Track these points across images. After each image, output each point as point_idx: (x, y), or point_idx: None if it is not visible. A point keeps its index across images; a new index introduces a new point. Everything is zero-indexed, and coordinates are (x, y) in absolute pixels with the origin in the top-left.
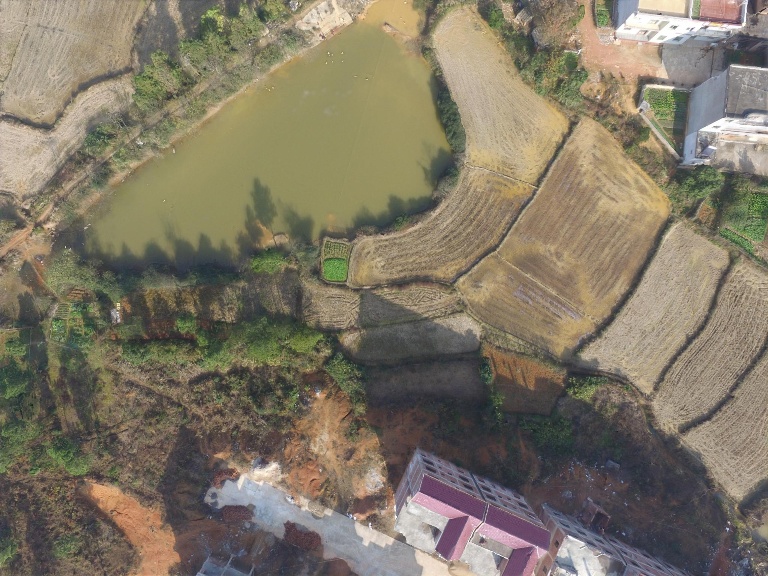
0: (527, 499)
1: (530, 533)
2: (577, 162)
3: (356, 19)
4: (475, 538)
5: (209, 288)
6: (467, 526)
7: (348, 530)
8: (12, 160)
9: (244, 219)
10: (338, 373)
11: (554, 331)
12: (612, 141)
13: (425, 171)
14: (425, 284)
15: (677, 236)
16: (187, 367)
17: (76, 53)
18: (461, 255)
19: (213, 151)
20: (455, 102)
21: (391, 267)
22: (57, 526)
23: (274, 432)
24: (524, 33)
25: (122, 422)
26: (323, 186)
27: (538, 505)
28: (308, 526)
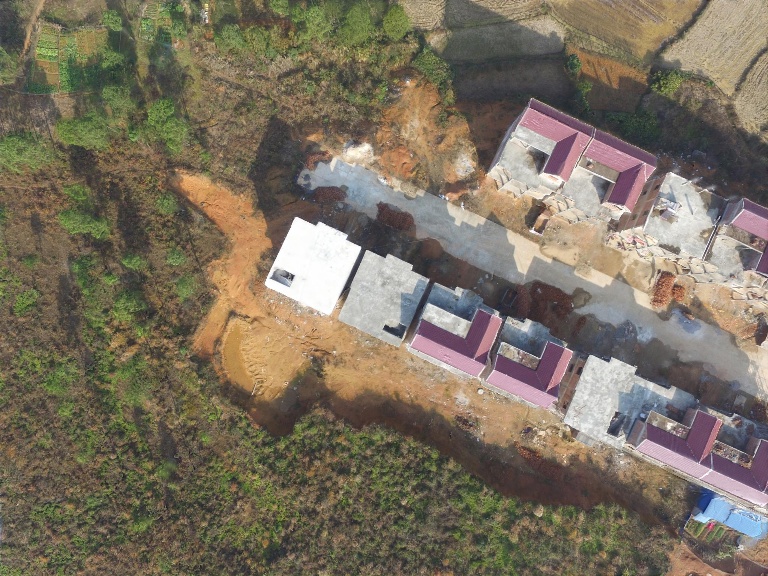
0: None
1: (637, 153)
2: None
3: None
4: (582, 162)
5: None
6: (576, 144)
7: (440, 210)
8: None
9: None
10: (427, 64)
11: (637, 34)
12: None
13: None
14: None
15: None
16: (277, 62)
17: None
18: None
19: None
20: None
21: None
22: (148, 215)
23: (364, 121)
24: None
25: (212, 117)
26: None
27: None
28: (401, 207)
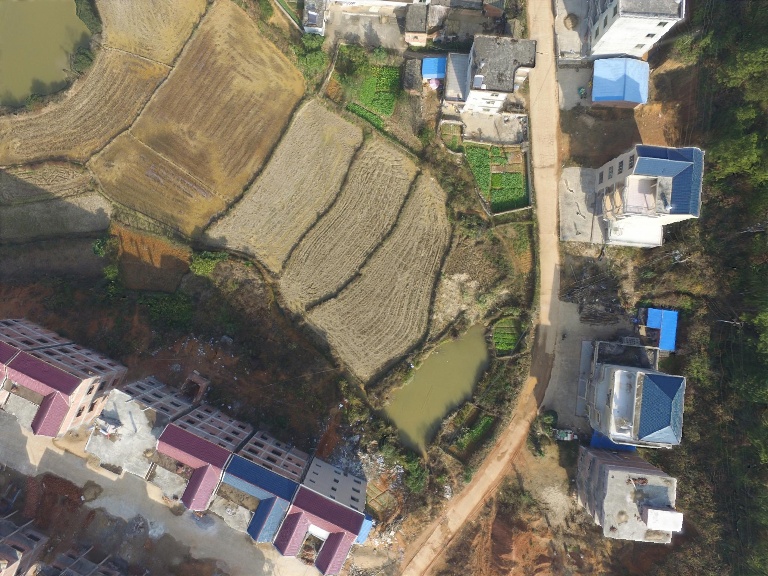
0: (133, 371)
1: (56, 379)
2: (212, 42)
3: None
4: (7, 385)
5: None
6: None
7: None
8: None
9: None
10: None
11: (185, 210)
12: (248, 20)
13: (67, 55)
14: (57, 163)
15: (309, 113)
16: None
17: None
18: (96, 135)
19: None
20: None
21: (27, 147)
22: None
23: None
24: None
25: None
26: None
27: (144, 377)
28: None
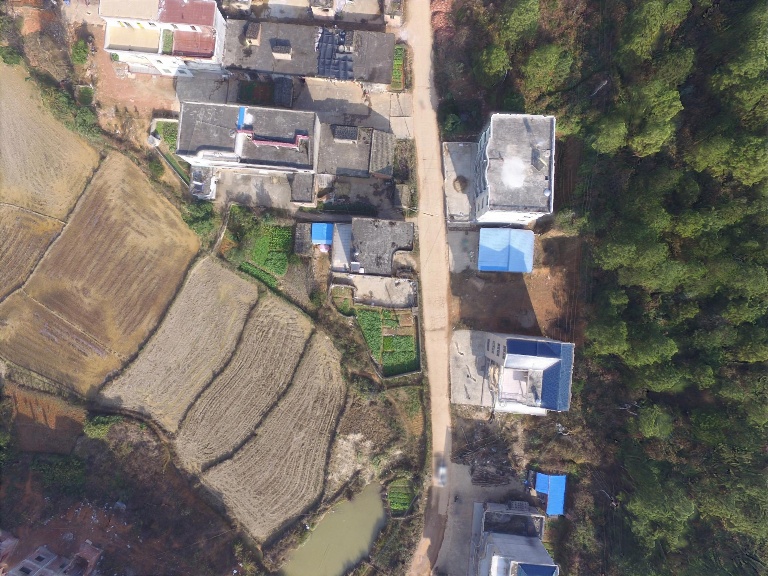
0: (24, 541)
1: None
2: (105, 197)
3: None
4: None
5: None
6: None
7: None
8: None
9: None
10: None
11: (80, 369)
12: (142, 175)
13: None
14: None
15: (204, 271)
16: None
17: None
18: None
19: None
20: None
21: None
22: None
23: None
24: None
25: None
26: None
27: (36, 548)
28: None
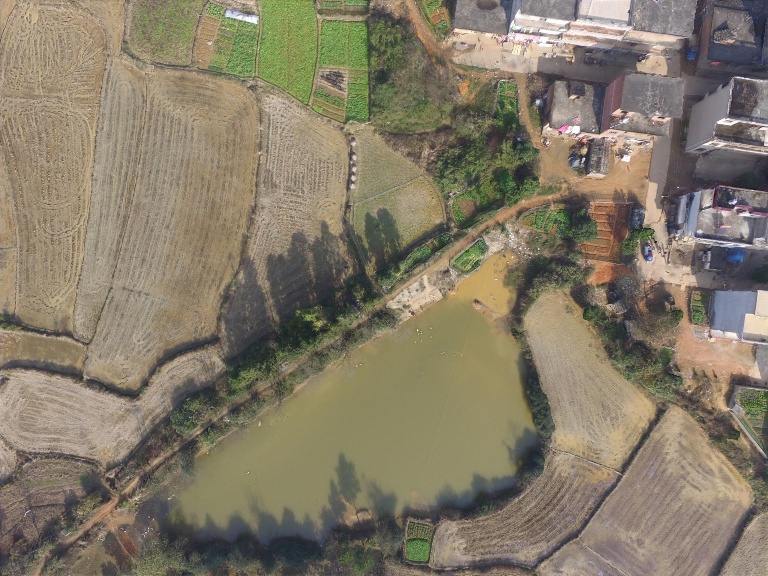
0: None
1: None
2: (662, 450)
3: (446, 295)
4: None
5: (292, 566)
6: None
7: None
8: (96, 427)
9: (327, 494)
10: None
11: None
12: (698, 429)
13: (509, 451)
14: (507, 569)
15: (758, 527)
16: None
17: (162, 318)
18: (543, 539)
19: (299, 427)
20: (546, 396)
21: (473, 549)
22: None
23: None
24: (616, 321)
25: None
26: (407, 463)
27: None
28: None
